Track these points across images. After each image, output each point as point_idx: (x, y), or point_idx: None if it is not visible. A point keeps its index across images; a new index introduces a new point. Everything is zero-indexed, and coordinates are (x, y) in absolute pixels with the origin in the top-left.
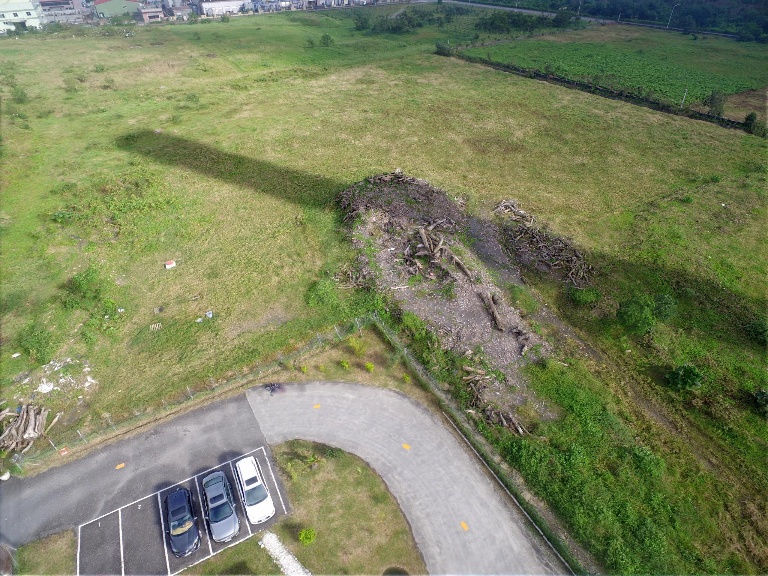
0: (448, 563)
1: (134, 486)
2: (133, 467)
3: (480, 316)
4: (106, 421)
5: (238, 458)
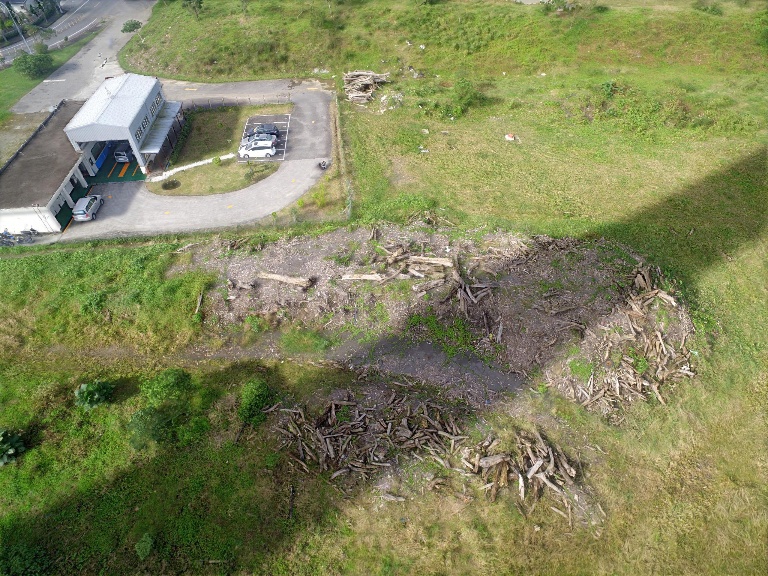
0: (160, 202)
1: (298, 125)
2: (309, 125)
3: (289, 270)
4: (348, 117)
5: (284, 151)
